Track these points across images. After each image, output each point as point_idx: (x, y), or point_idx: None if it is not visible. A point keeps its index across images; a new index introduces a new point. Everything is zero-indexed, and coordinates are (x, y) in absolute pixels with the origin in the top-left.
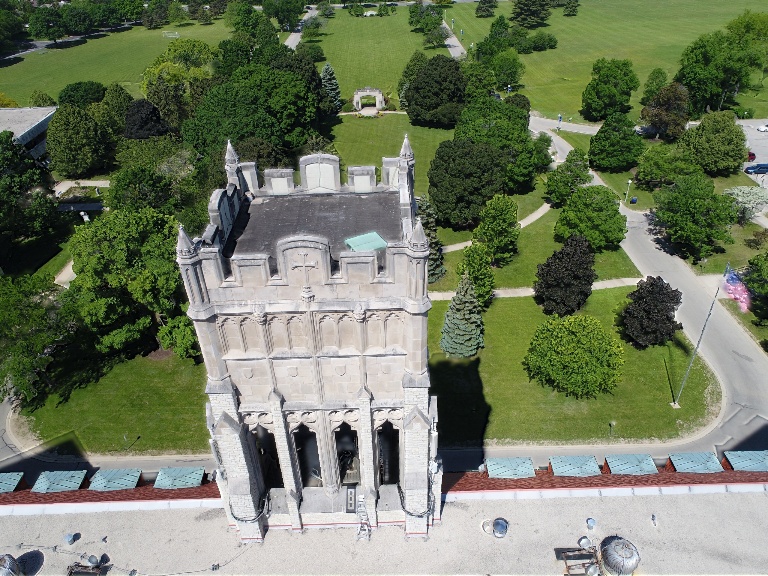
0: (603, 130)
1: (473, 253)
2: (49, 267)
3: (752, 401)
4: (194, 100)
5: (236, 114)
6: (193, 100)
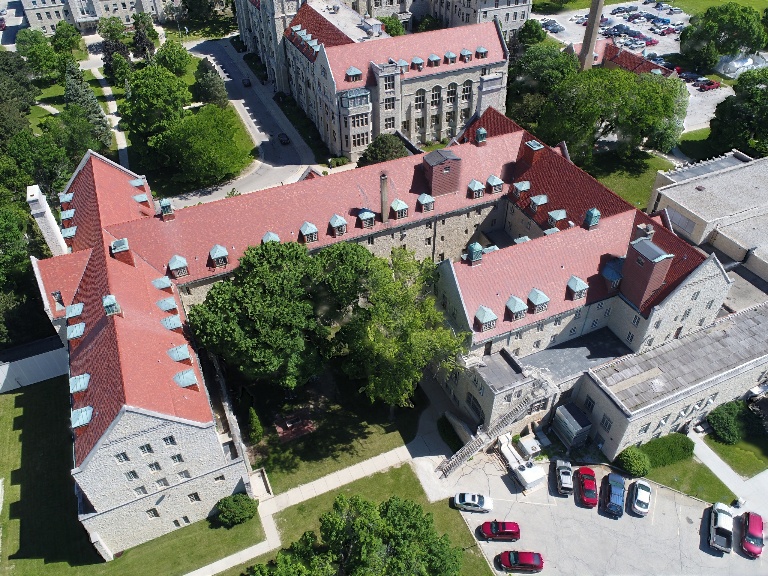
0: None
1: None
2: None
3: None
4: None
5: None
6: None
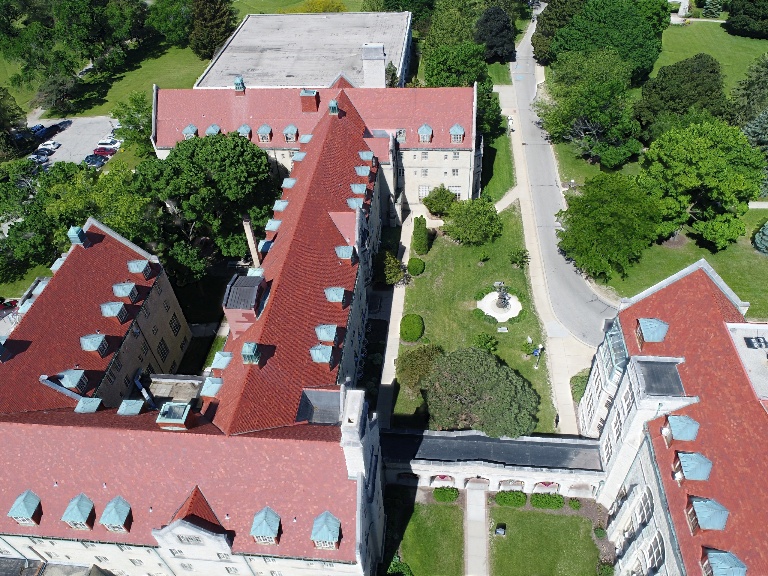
0: None
1: None
2: (501, 165)
3: None
4: (553, 8)
5: (624, 25)
6: (551, 8)
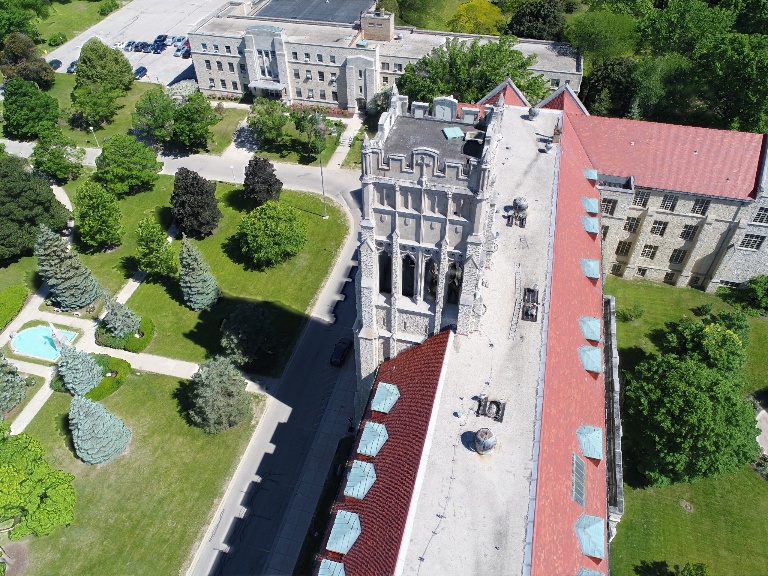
0: (11, 101)
1: (146, 231)
2: None
3: (339, 189)
4: None
5: None
6: None
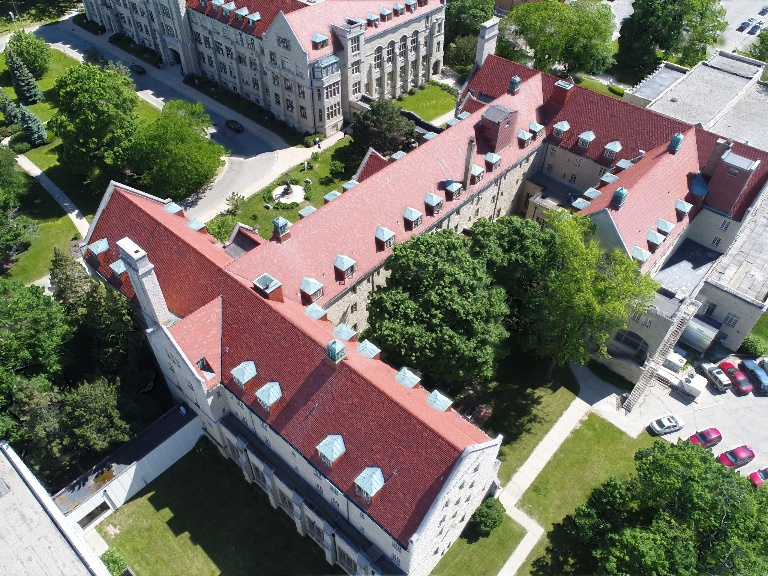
0: None
1: None
2: None
3: None
4: None
5: None
6: None
